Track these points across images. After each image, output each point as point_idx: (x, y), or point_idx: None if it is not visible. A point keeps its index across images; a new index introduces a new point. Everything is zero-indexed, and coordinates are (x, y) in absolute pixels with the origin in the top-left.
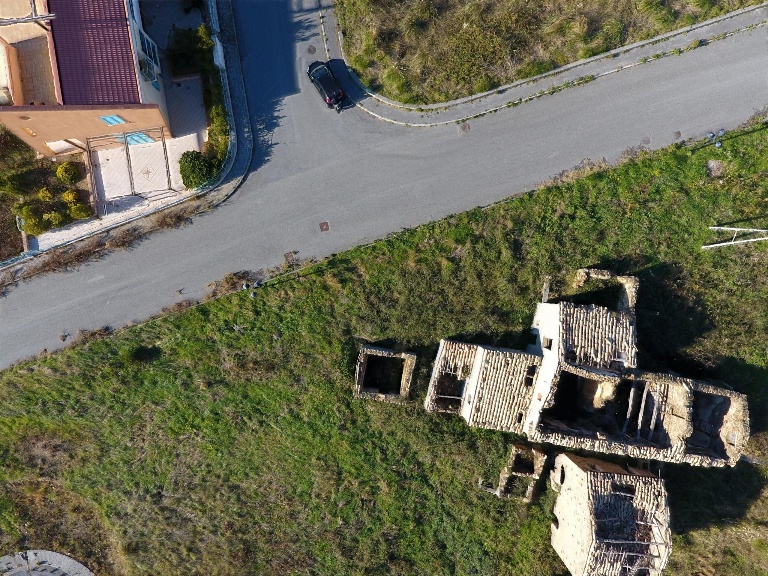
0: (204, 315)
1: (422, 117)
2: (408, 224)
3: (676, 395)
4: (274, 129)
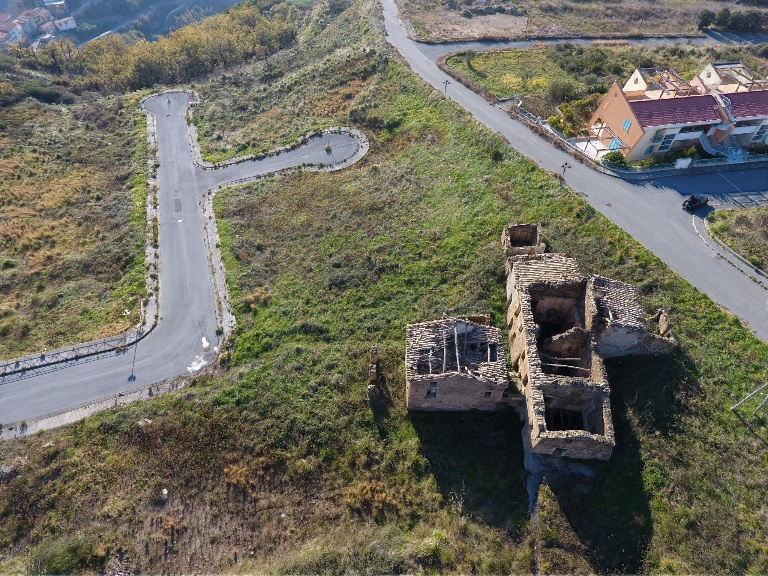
0: (531, 170)
1: (709, 239)
2: (634, 236)
3: None
4: (654, 186)
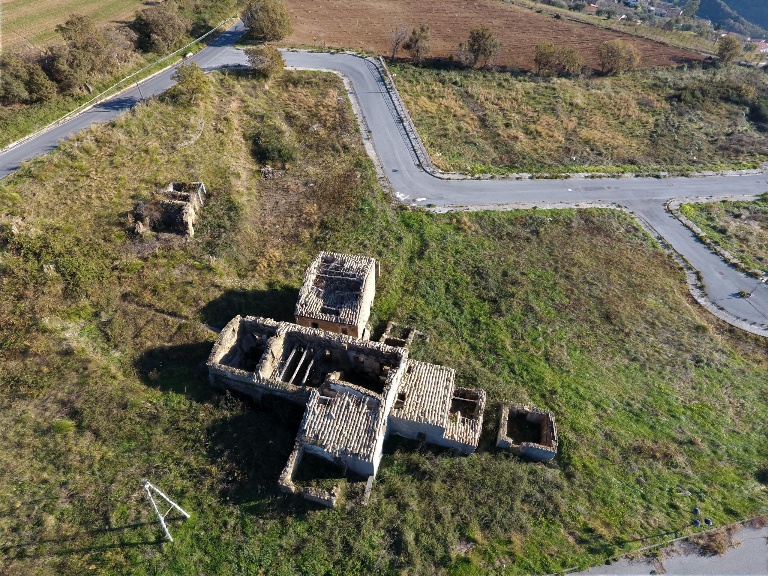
0: (730, 510)
1: None
2: None
3: (268, 372)
4: None
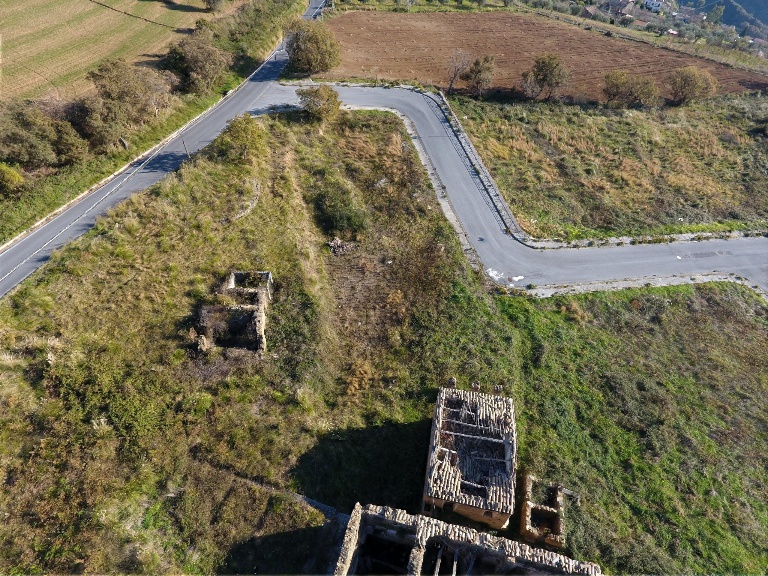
0: None
1: None
2: None
3: None
4: None
